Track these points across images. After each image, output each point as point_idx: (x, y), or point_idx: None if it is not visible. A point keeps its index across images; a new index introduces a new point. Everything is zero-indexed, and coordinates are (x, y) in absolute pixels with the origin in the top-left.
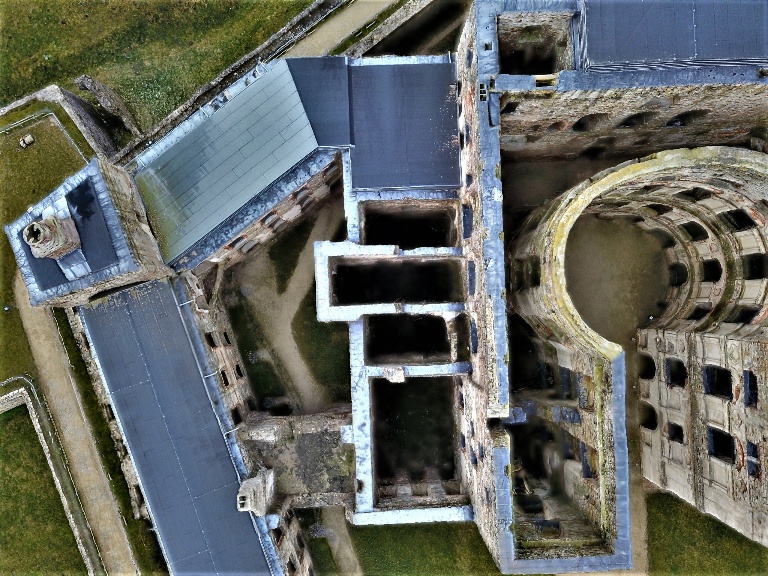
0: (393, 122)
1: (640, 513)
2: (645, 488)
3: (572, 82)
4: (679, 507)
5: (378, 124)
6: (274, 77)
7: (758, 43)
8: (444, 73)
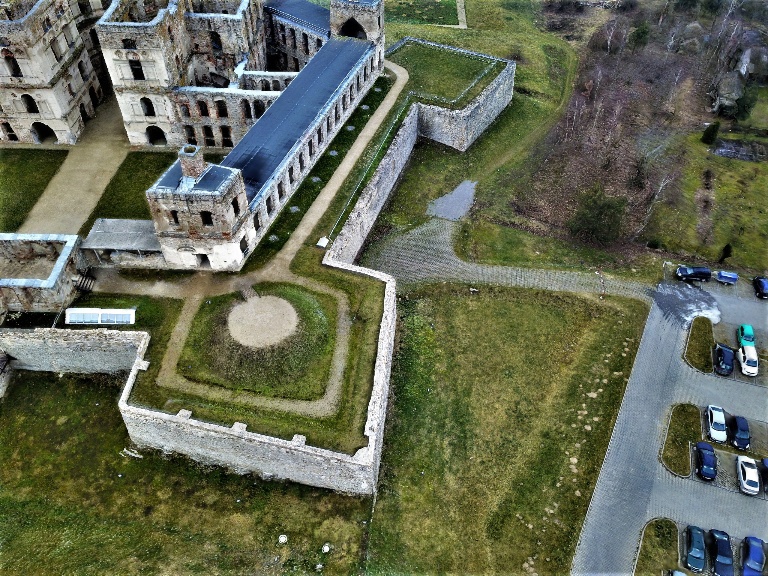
0: None
1: (122, 158)
2: (130, 150)
3: None
4: (146, 157)
5: None
6: None
7: None
8: None
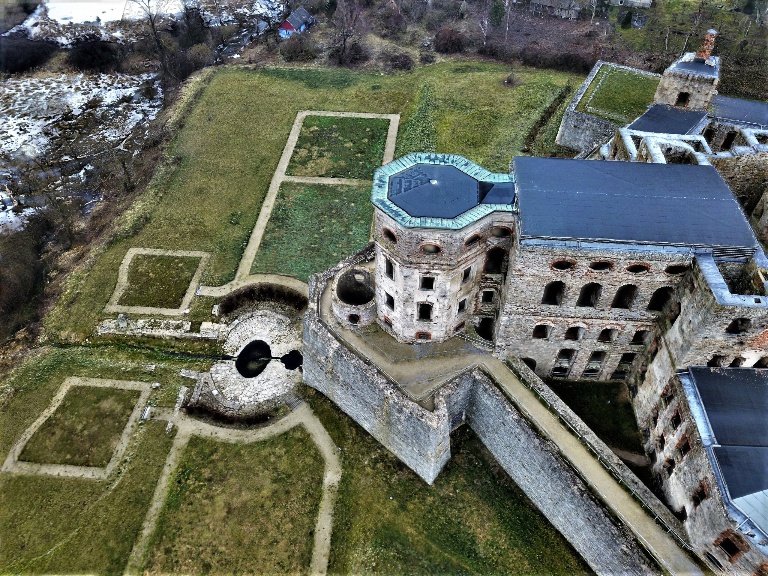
0: (761, 415)
1: None
2: None
3: (763, 261)
4: None
5: (767, 427)
6: (755, 512)
7: (712, 177)
8: (702, 376)
